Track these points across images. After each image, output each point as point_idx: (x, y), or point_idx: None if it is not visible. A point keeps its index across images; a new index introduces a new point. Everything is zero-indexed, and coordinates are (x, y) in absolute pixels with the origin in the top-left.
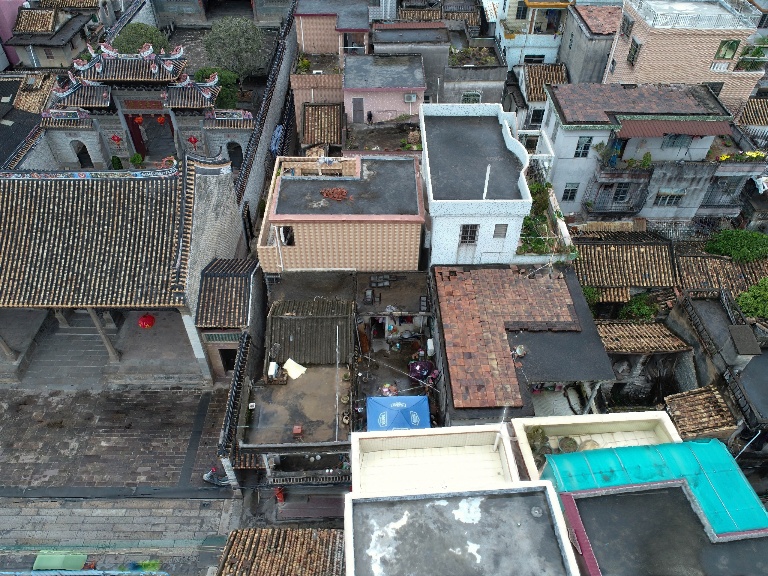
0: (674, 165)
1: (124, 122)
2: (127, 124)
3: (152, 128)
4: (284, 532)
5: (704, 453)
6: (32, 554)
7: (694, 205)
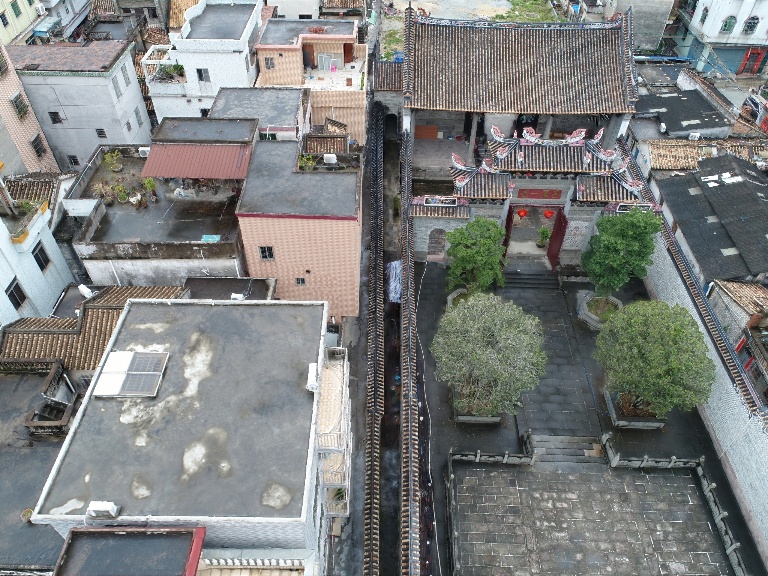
0: None
1: None
2: None
3: (586, 337)
4: (345, 5)
5: None
6: None
7: None
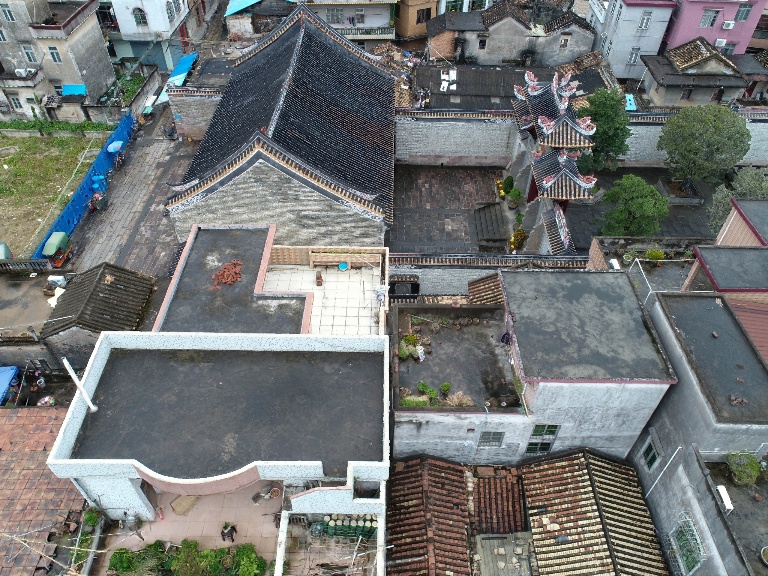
0: None
1: None
2: None
3: None
4: None
5: None
6: (89, 240)
7: None
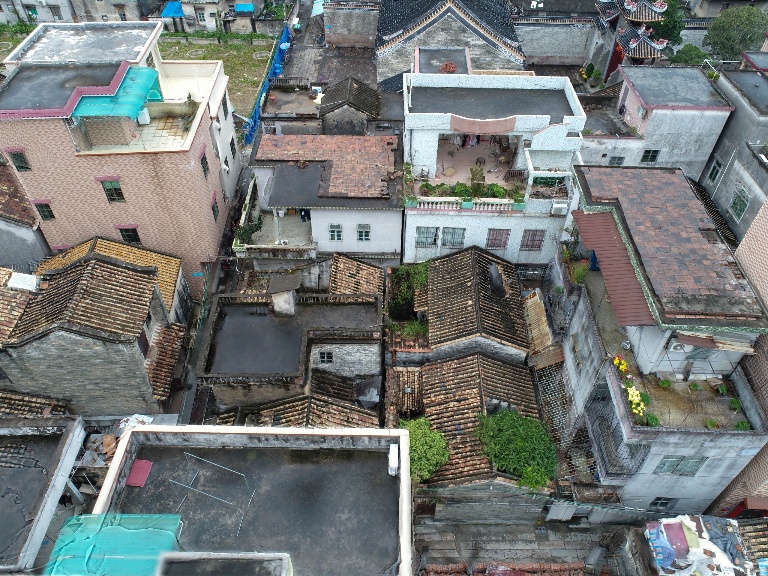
0: (589, 309)
1: (613, 44)
2: (614, 47)
3: None
4: None
5: (126, 107)
6: None
7: (583, 396)
